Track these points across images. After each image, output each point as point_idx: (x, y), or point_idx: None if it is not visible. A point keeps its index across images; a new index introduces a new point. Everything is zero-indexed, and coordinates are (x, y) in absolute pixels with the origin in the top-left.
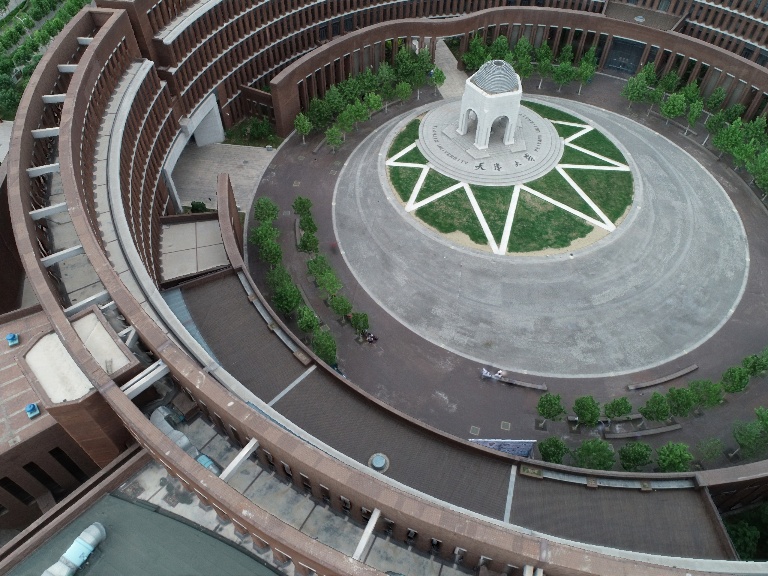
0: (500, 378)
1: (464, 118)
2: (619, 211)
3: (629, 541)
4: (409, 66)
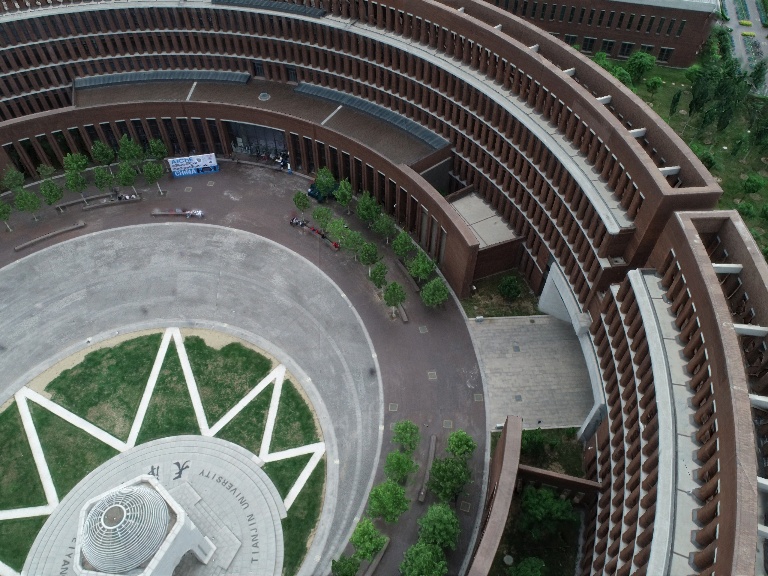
0: None
1: None
2: None
3: (128, 91)
4: None
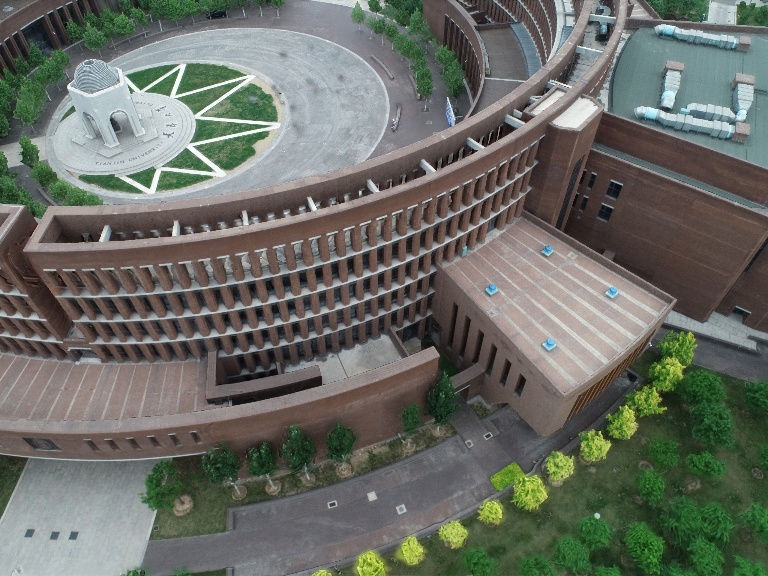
0: (397, 122)
1: (111, 128)
2: (234, 72)
3: (510, 49)
4: (6, 160)
